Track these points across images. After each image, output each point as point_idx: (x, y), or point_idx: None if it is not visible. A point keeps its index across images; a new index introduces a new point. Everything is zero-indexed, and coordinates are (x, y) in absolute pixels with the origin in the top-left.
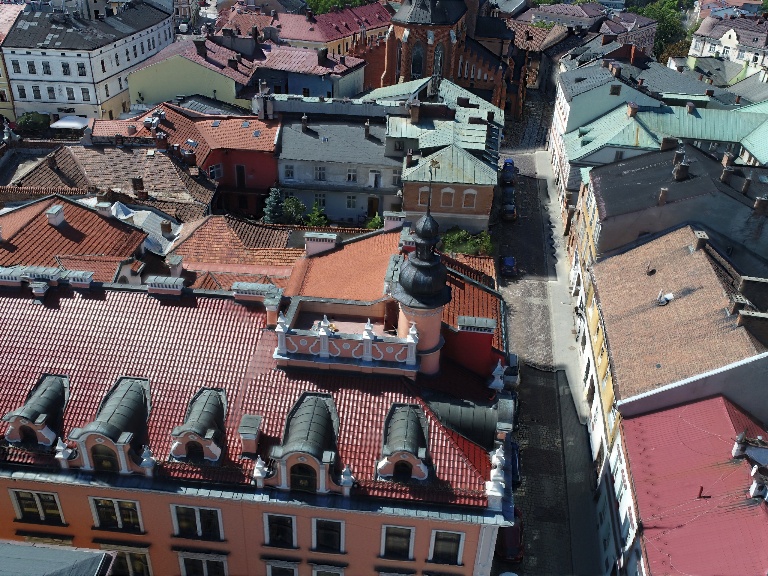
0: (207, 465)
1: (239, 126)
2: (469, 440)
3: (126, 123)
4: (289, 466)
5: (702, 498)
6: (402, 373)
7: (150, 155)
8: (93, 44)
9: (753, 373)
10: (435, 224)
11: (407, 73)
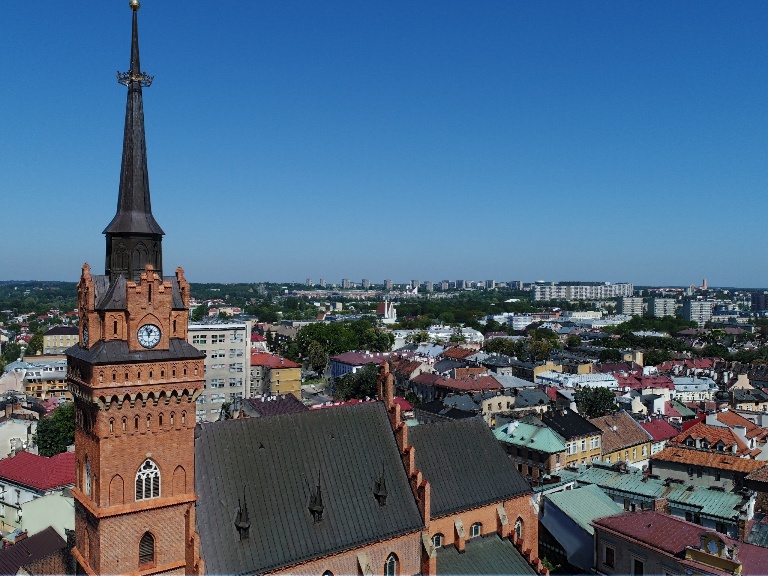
0: None
1: None
2: None
3: None
4: None
5: None
6: None
7: None
8: None
9: None
10: None
11: None
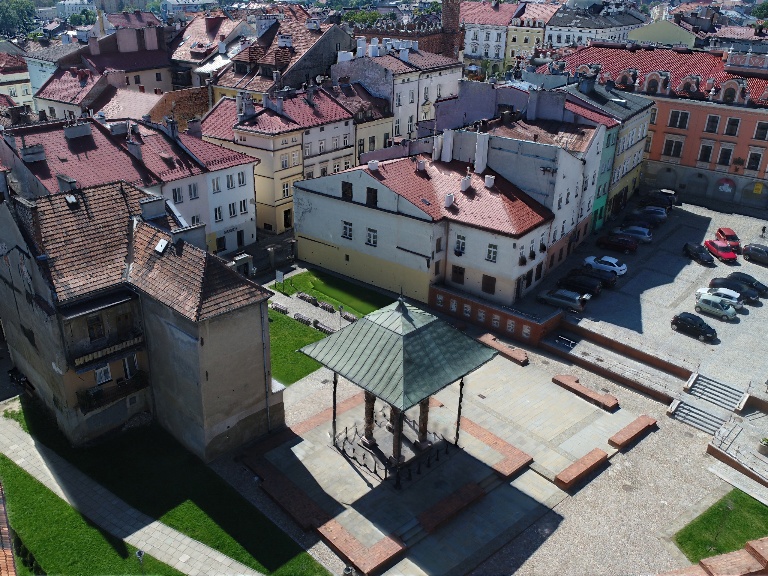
0: (691, 91)
1: None
2: None
3: None
4: (725, 89)
5: None
6: None
7: None
8: (600, 26)
9: None
10: None
11: None
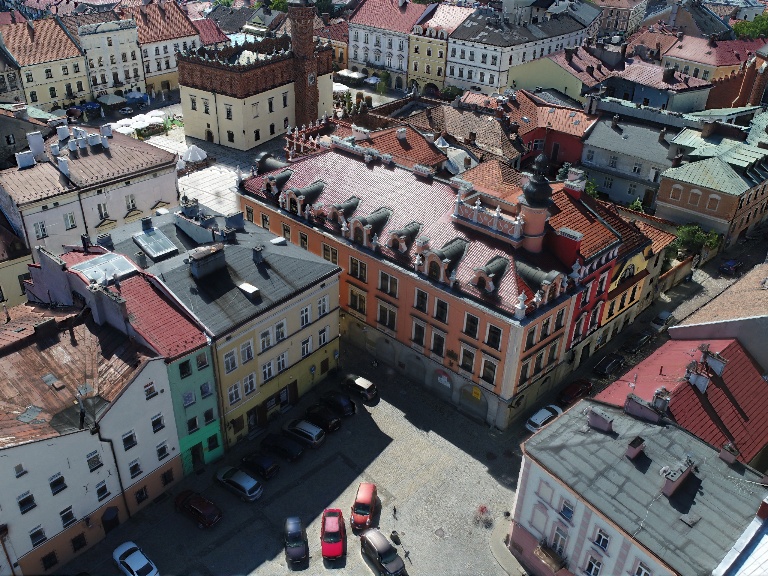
0: (398, 252)
1: (567, 115)
2: (528, 286)
3: (488, 98)
4: (429, 261)
5: (661, 375)
6: (510, 242)
7: (489, 120)
8: (508, 43)
9: (759, 327)
10: (545, 159)
11: (756, 101)
